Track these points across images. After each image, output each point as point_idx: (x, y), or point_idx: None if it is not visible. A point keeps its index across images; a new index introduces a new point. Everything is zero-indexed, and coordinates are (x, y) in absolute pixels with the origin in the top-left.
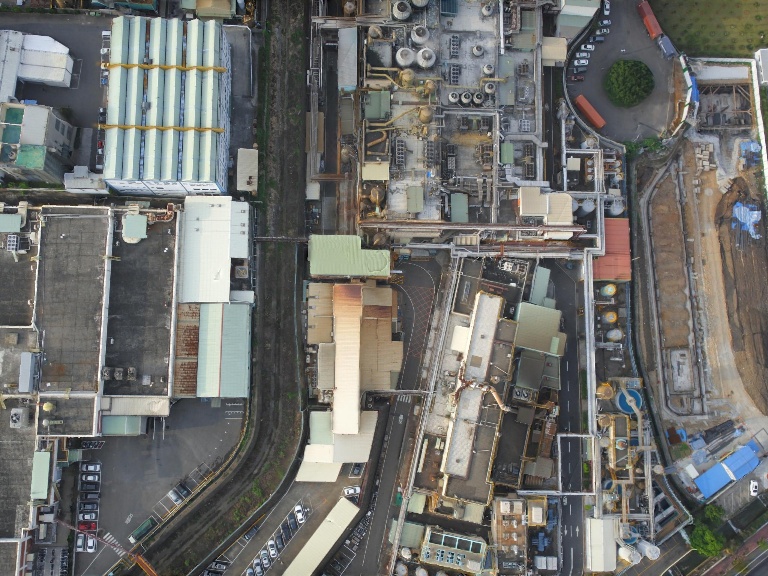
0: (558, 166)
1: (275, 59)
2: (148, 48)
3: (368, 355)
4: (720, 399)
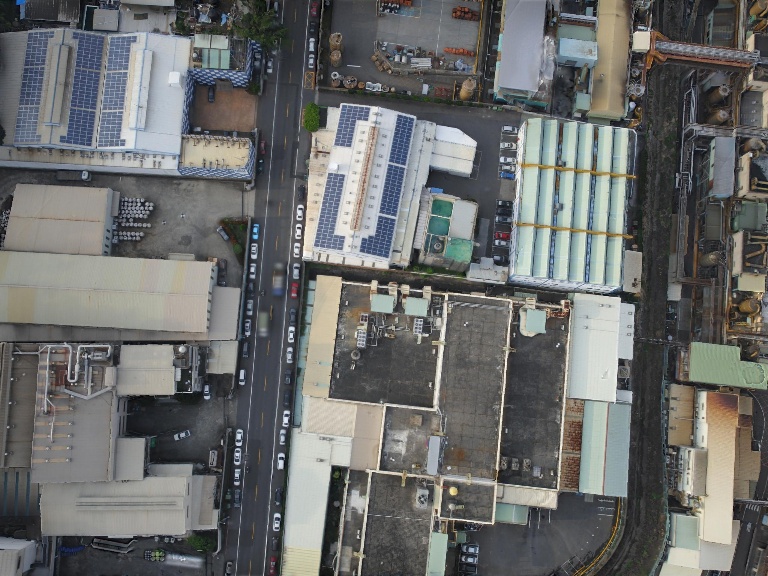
0: None
1: (648, 160)
2: (561, 150)
3: None
4: None
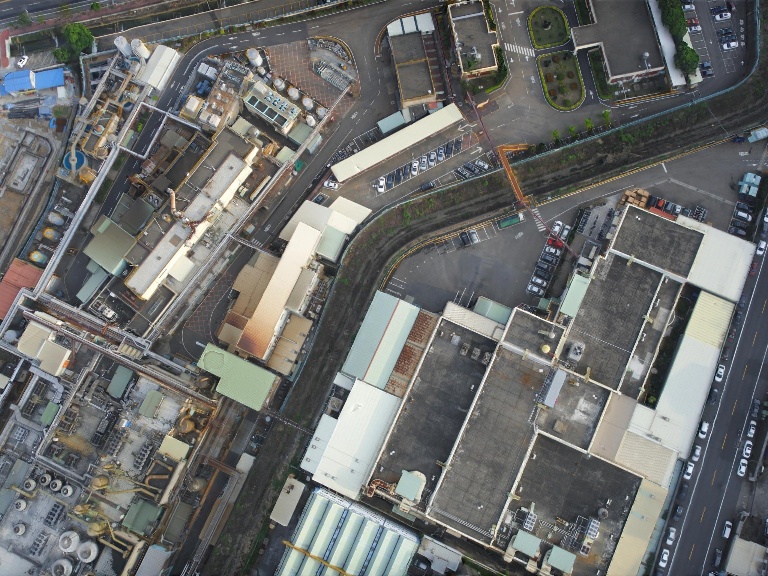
0: (18, 389)
1: None
2: None
3: (264, 287)
4: (7, 137)
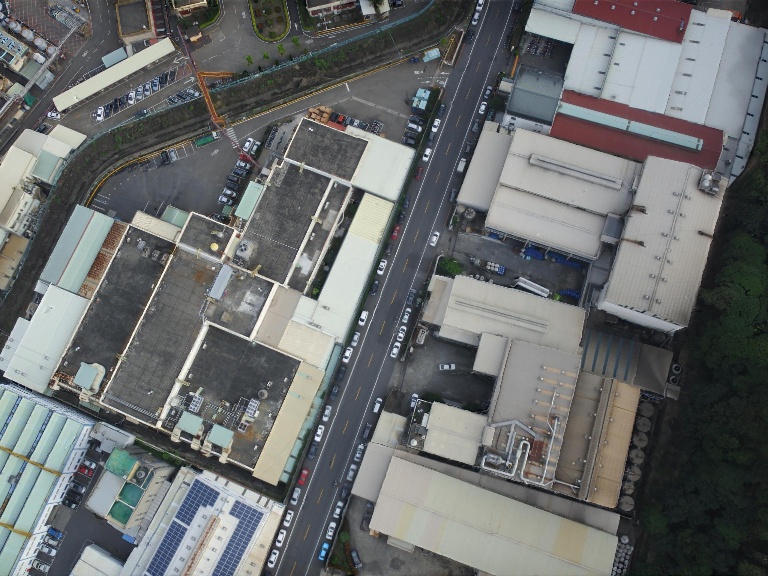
0: None
1: None
2: None
3: None
4: None
